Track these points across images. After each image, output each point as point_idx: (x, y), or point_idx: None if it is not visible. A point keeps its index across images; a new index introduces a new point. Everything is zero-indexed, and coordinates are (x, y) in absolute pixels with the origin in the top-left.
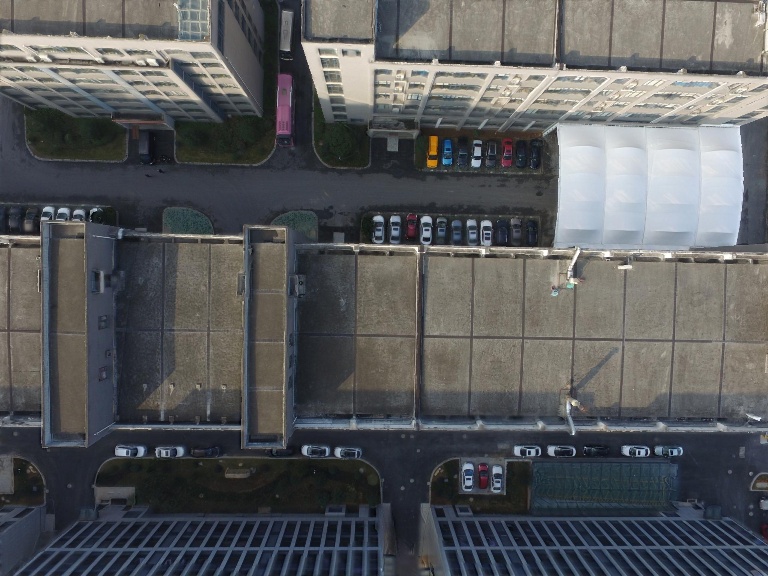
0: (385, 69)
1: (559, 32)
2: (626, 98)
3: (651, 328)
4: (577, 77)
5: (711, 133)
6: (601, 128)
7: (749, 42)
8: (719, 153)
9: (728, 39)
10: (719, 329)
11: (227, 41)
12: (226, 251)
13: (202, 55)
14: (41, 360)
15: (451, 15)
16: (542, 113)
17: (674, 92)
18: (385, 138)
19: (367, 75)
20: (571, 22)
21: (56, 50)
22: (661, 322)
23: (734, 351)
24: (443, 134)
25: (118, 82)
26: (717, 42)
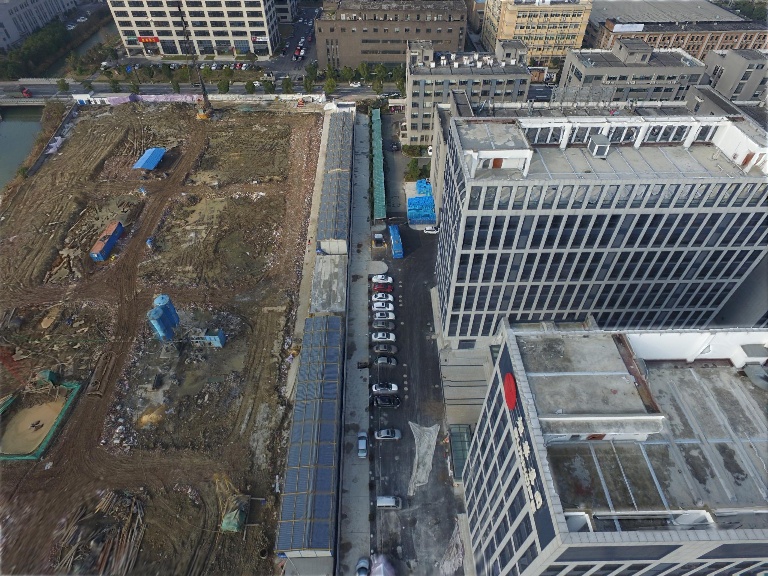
0: (766, 79)
1: None
2: None
3: None
4: None
5: None
6: None
7: None
8: None
9: None
10: None
11: None
12: (752, 107)
13: (691, 80)
14: (721, 109)
15: None
16: None
17: None
18: None
19: (756, 84)
20: None
21: (640, 79)
22: None
23: None
24: None
25: (646, 99)
26: None
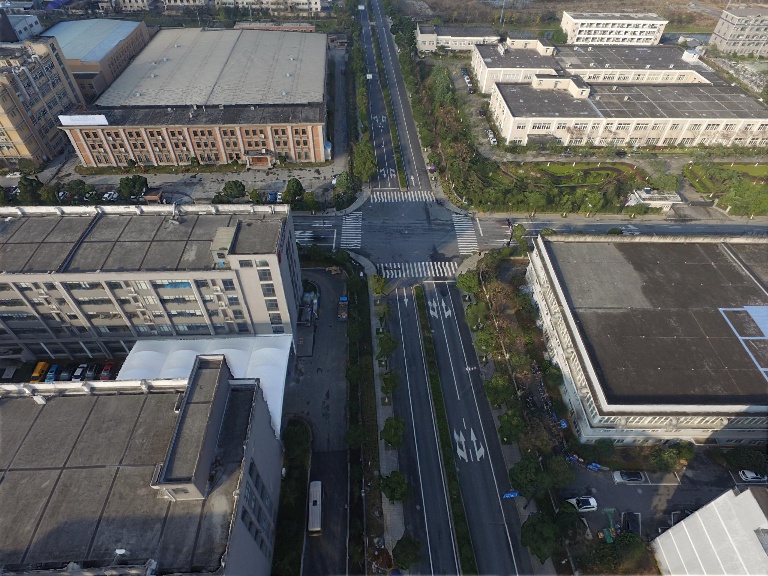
0: None
1: (66, 258)
2: (151, 306)
3: (44, 456)
4: (82, 284)
5: (266, 340)
6: (172, 342)
7: (207, 258)
8: (263, 350)
9: (192, 257)
10: (119, 453)
11: None
12: None
13: None
14: None
15: None
16: (116, 331)
17: (177, 296)
18: (5, 369)
19: None
20: (80, 254)
21: None
22: (58, 450)
23: (128, 476)
24: (58, 363)
25: None
26: (183, 259)
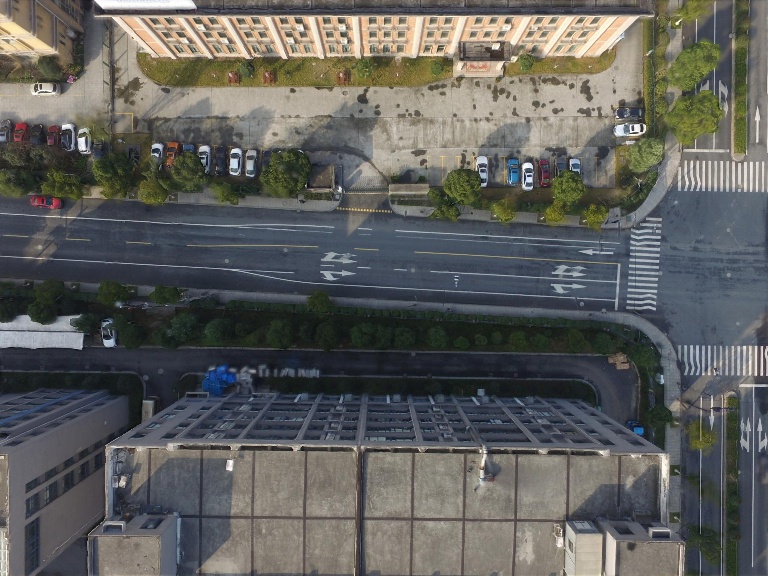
0: None
1: (357, 558)
2: None
3: None
4: None
5: None
6: None
7: (550, 558)
8: None
9: (529, 555)
10: None
11: (46, 541)
12: None
13: None
14: None
15: (252, 541)
16: None
17: None
18: None
19: None
20: (371, 545)
21: None
22: None
23: None
24: None
25: None
26: (518, 558)
